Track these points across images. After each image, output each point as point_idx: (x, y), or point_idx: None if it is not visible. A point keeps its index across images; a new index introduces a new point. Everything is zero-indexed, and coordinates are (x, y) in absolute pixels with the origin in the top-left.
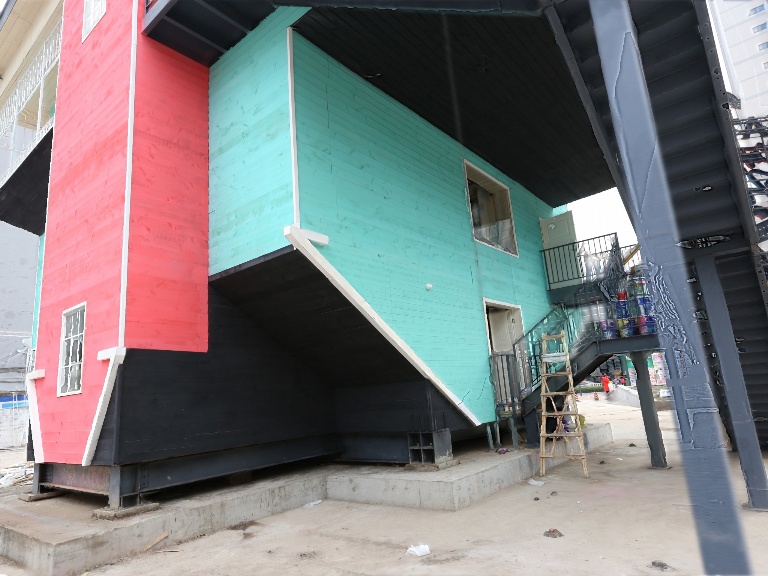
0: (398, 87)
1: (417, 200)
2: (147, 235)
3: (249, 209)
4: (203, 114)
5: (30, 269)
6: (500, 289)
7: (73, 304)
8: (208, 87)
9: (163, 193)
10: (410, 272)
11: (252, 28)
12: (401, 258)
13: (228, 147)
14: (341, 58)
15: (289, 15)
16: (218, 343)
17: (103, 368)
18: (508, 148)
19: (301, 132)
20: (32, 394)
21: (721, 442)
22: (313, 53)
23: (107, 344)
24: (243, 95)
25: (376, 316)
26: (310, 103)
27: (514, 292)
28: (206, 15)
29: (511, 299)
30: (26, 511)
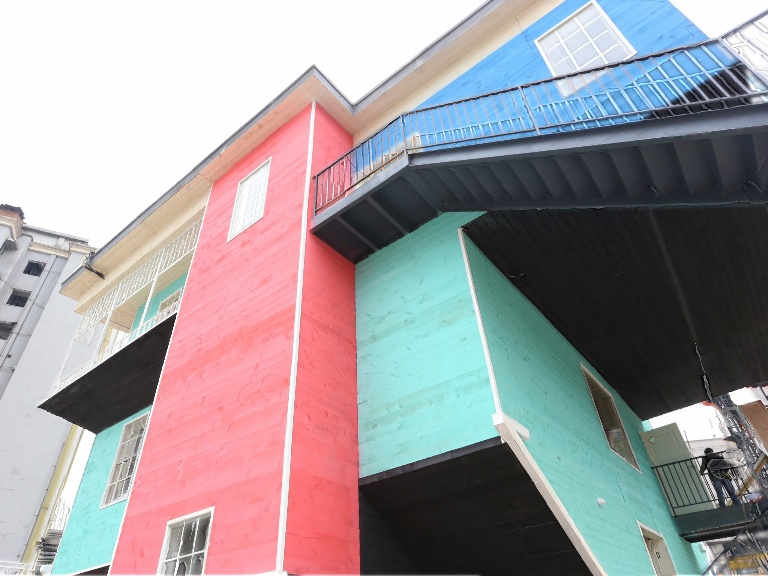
0: (535, 288)
1: (564, 399)
2: (308, 424)
3: (421, 398)
4: (351, 304)
5: (20, 480)
6: (643, 511)
7: (188, 511)
8: (354, 281)
9: (321, 378)
10: (583, 482)
11: (411, 230)
12: (573, 463)
13: (385, 335)
14: (494, 258)
15: (459, 219)
16: (369, 571)
17: None
18: (617, 353)
19: (484, 318)
20: None
21: None
22: (476, 251)
23: (252, 567)
24: (403, 286)
25: (580, 537)
26: (483, 293)
27: (652, 516)
28: (370, 219)
29: (653, 525)
30: None
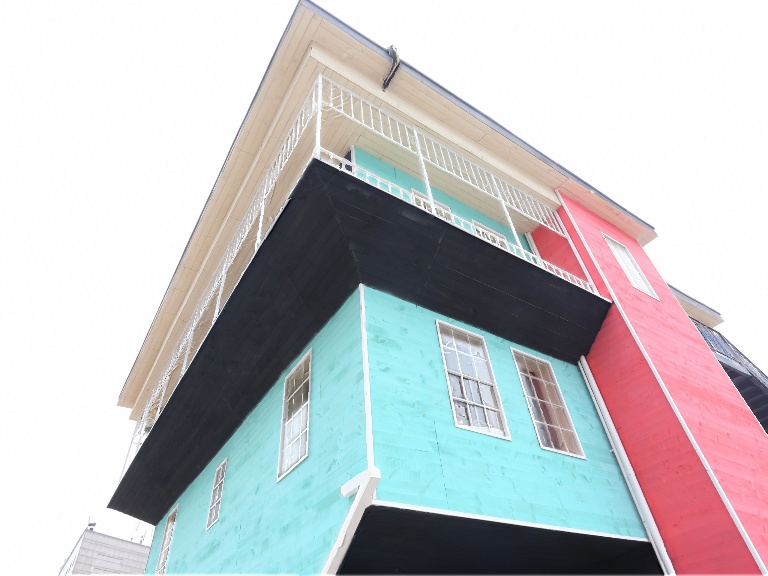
0: None
1: None
2: None
3: None
4: None
5: None
6: None
7: None
8: None
9: None
10: None
11: None
12: None
13: None
14: None
15: None
16: None
17: None
18: None
19: None
20: None
21: None
22: None
23: None
24: None
25: None
26: None
27: None
28: None
29: None
30: None
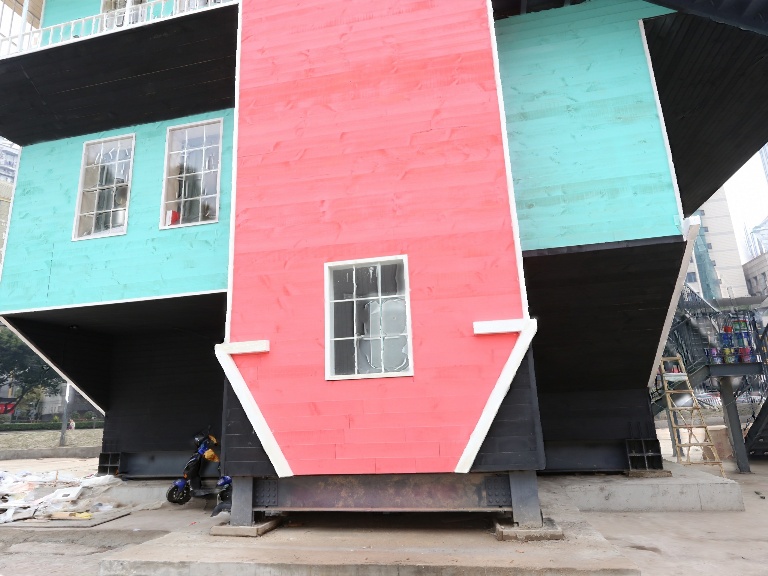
0: None
1: None
2: None
3: (591, 188)
4: None
5: None
6: None
7: (361, 255)
8: None
9: None
10: None
11: (574, 3)
12: None
13: (539, 115)
14: None
15: (641, 8)
16: None
17: (481, 344)
18: None
19: None
20: (238, 375)
21: (729, 454)
22: None
23: (486, 314)
24: (564, 67)
25: None
26: None
27: None
28: None
29: None
30: (326, 546)
